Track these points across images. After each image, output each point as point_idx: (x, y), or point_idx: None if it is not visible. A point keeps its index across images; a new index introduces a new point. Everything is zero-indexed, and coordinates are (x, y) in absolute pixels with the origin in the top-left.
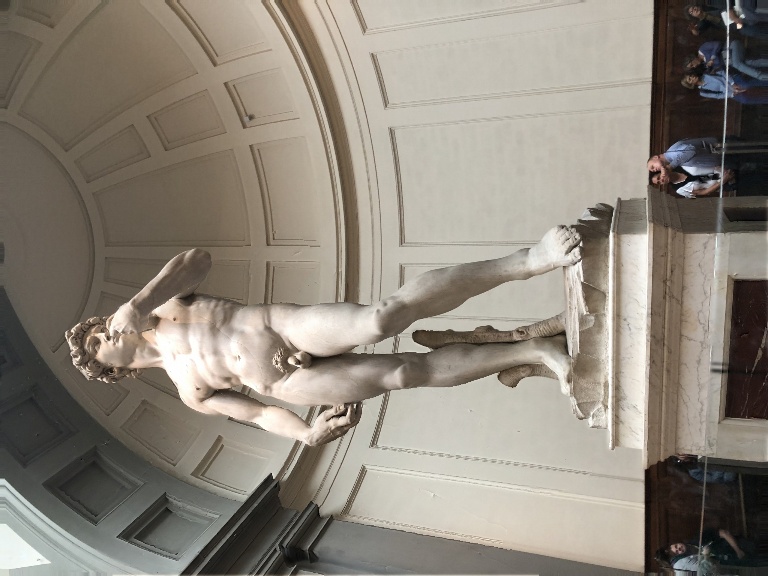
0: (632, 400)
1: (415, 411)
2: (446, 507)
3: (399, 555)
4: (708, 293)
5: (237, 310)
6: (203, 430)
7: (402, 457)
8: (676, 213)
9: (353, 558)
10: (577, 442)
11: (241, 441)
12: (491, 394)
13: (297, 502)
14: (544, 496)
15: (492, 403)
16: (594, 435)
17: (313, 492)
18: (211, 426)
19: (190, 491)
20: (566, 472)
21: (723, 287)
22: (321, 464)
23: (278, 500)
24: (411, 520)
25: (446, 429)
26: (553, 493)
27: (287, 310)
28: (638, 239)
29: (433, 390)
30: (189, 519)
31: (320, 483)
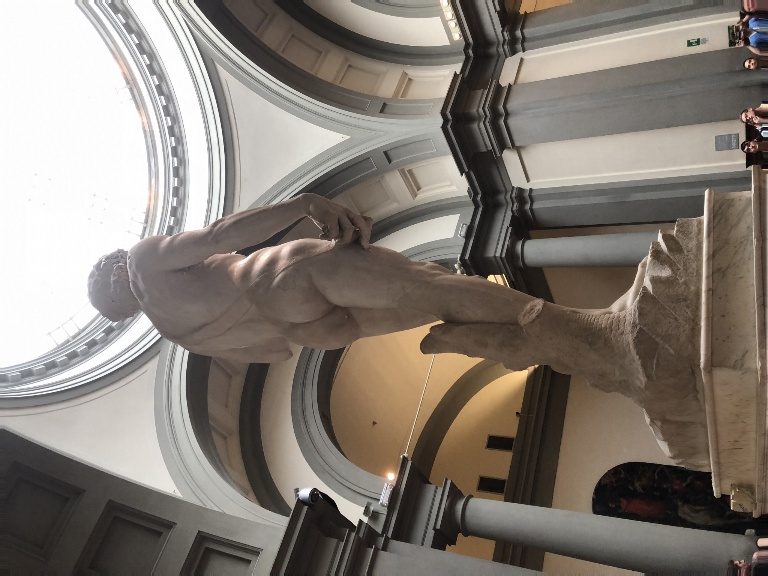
0: None
1: None
2: None
3: None
4: None
5: None
6: None
7: None
8: None
9: None
10: None
11: None
12: None
13: None
14: None
15: None
16: None
17: None
18: None
19: None
20: None
21: None
22: None
23: None
24: None
25: None
26: None
27: None
28: None
29: None
30: None
31: None
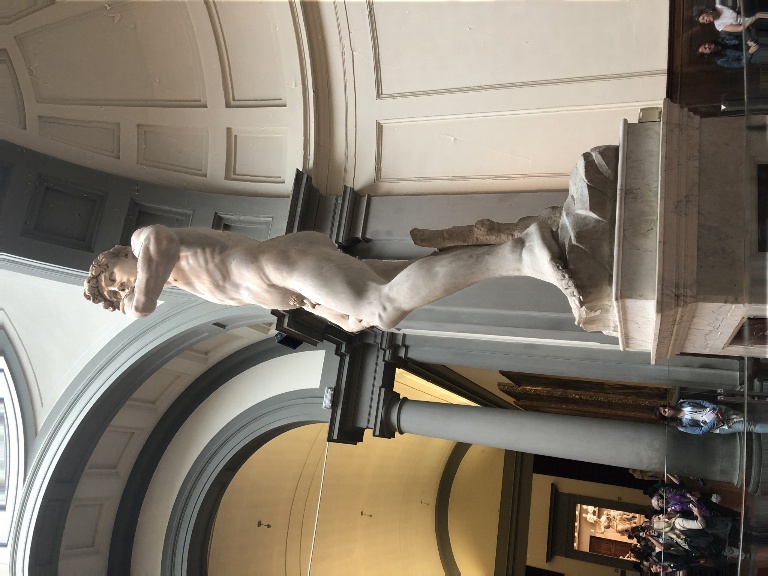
0: (641, 339)
1: (410, 44)
2: (469, 150)
3: (439, 223)
4: (720, 319)
5: (229, 264)
6: (209, 128)
7: (412, 104)
8: (694, 210)
9: (401, 237)
10: (592, 41)
11: (250, 126)
12: (488, 2)
13: (331, 180)
14: (562, 114)
15: (492, 12)
16: (610, 27)
17: (341, 166)
18: (214, 122)
19: (234, 201)
20: (582, 83)
21: (737, 320)
22: (337, 132)
23: (315, 190)
24: (439, 171)
25: (448, 57)
26: (571, 109)
27: (281, 273)
28: (645, 301)
29: (422, 13)
30: (248, 226)
31: (344, 153)
